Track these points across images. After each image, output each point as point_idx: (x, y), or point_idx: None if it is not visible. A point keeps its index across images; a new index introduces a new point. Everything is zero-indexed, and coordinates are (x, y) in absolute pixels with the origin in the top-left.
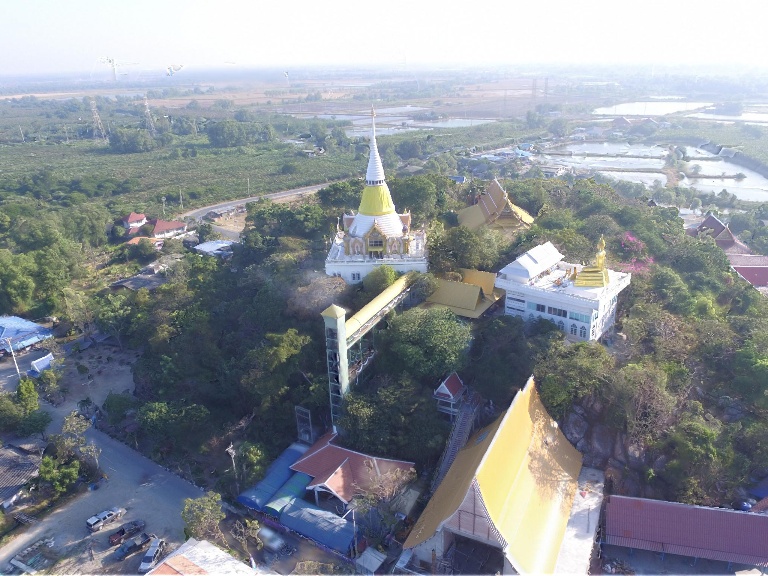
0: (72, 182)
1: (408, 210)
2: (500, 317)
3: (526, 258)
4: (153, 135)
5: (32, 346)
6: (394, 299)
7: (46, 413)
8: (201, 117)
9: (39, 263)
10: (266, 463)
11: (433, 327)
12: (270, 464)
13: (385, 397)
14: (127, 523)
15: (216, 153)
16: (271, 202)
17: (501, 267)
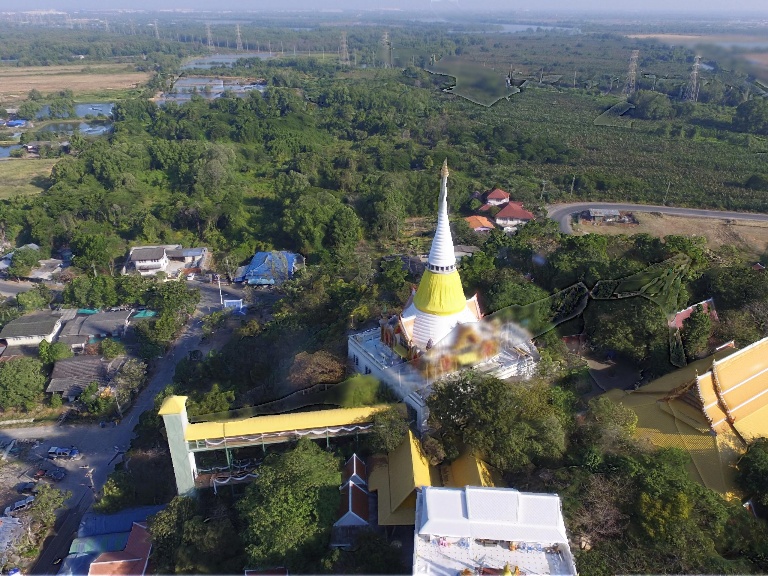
0: (527, 140)
1: (610, 313)
2: (389, 550)
3: (452, 496)
4: (673, 102)
5: (270, 285)
6: (329, 427)
7: (161, 347)
8: (759, 88)
9: (335, 217)
10: (120, 502)
11: (274, 495)
12: (138, 506)
13: (188, 530)
14: (65, 468)
15: (721, 137)
16: (555, 228)
17: (522, 479)
